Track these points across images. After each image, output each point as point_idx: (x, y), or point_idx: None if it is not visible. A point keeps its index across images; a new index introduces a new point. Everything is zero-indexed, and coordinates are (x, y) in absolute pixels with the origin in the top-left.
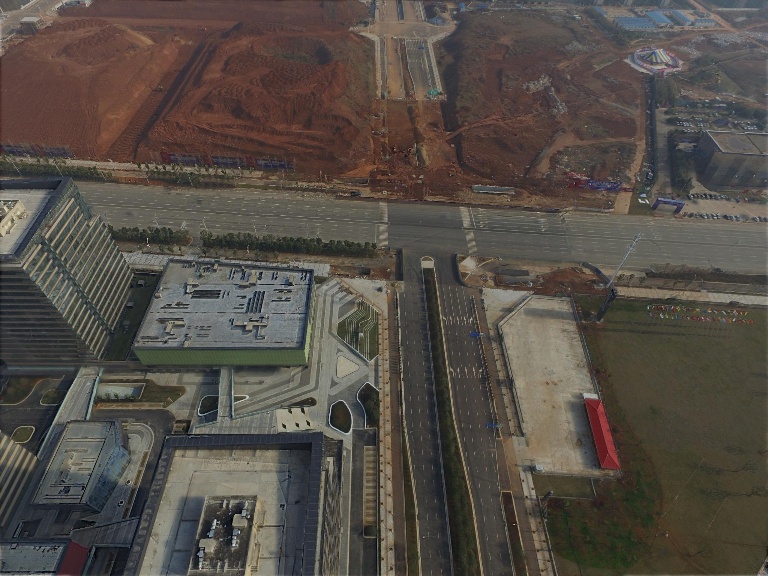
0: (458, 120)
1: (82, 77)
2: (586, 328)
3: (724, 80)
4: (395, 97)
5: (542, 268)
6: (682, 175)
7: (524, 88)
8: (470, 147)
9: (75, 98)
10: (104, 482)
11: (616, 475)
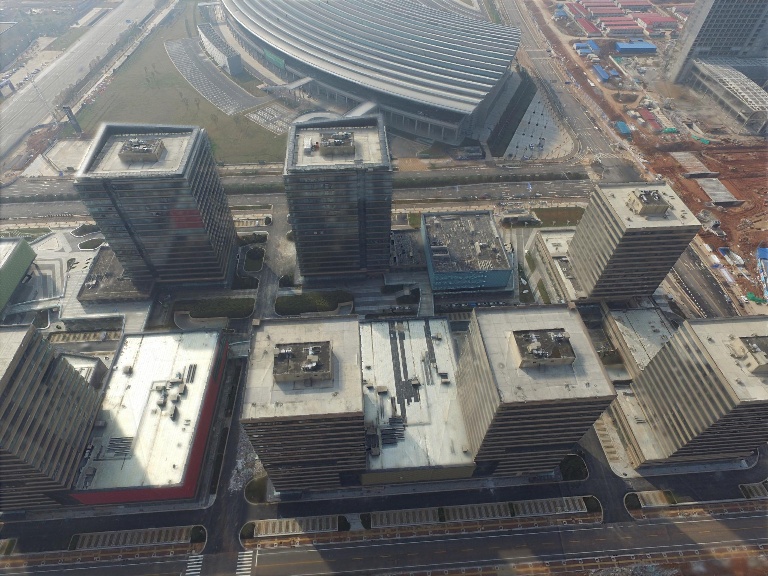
0: None
1: None
2: (84, 137)
3: None
4: None
5: (20, 148)
6: None
7: None
8: None
9: None
10: None
11: None
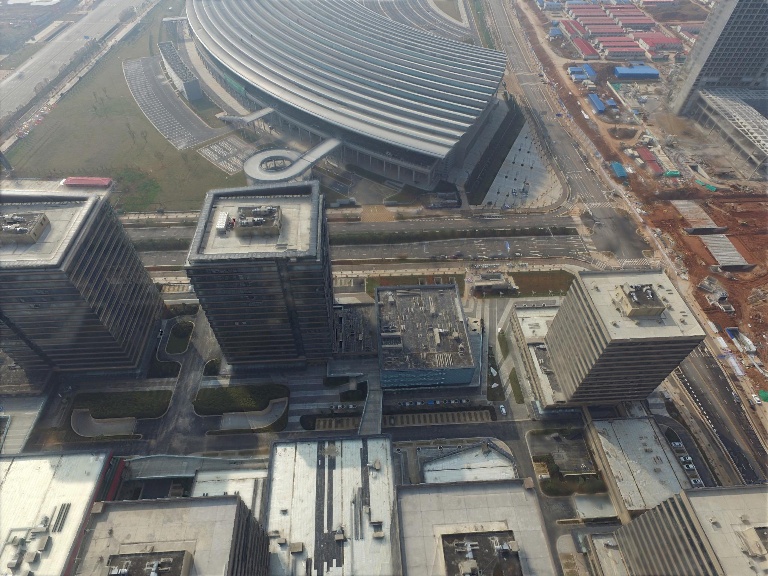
0: None
1: None
2: (13, 176)
3: None
4: None
5: None
6: None
7: None
8: None
9: None
10: None
11: (115, 182)
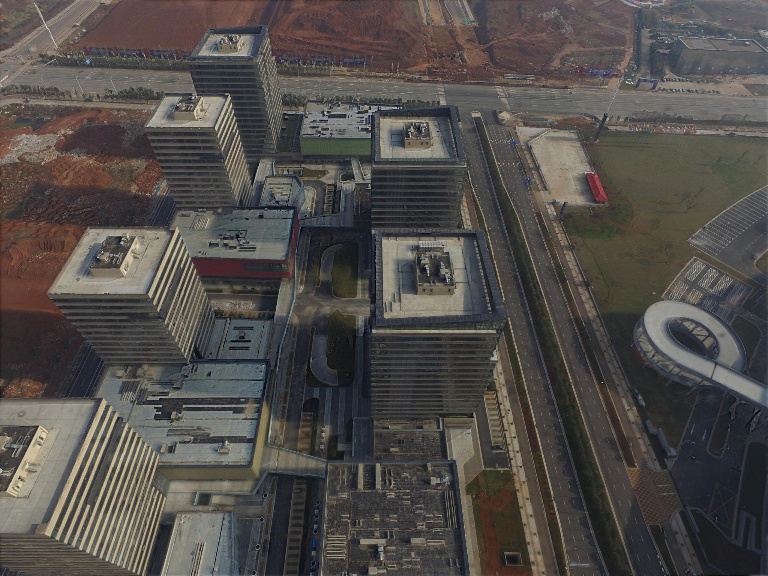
0: (489, 36)
1: (199, 7)
2: (587, 145)
3: (698, 11)
4: (438, 24)
5: (556, 117)
6: (659, 67)
7: (539, 17)
8: (500, 52)
9: (198, 21)
10: (298, 200)
11: (605, 206)
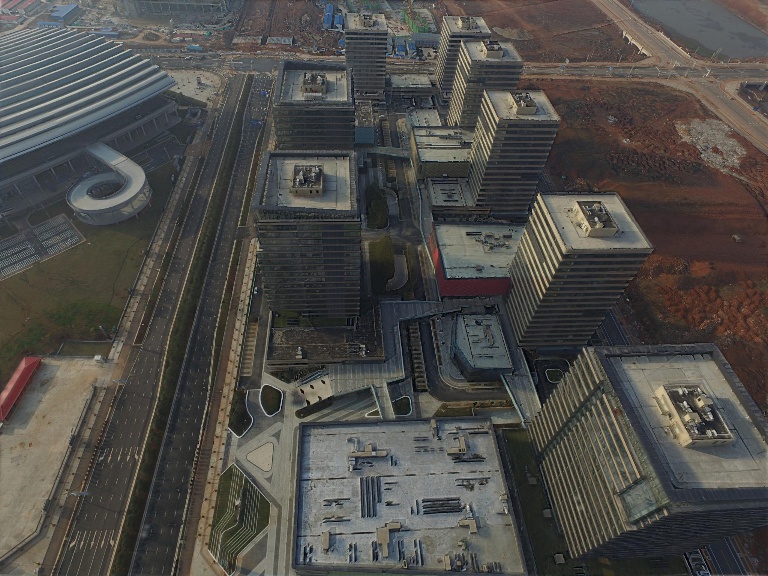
0: None
1: None
2: None
3: None
4: None
5: None
6: None
7: None
8: None
9: None
10: None
11: None
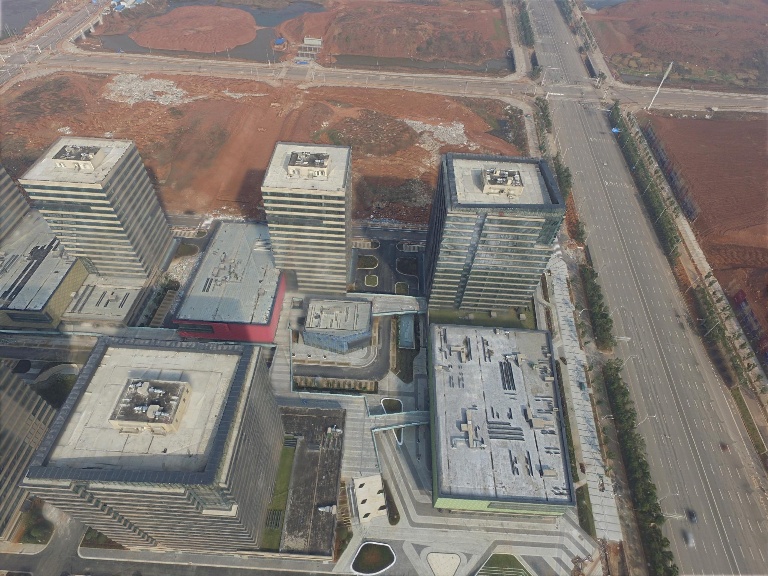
0: None
1: None
2: None
3: None
4: None
5: None
6: None
7: None
8: None
9: None
10: (320, 338)
11: None
